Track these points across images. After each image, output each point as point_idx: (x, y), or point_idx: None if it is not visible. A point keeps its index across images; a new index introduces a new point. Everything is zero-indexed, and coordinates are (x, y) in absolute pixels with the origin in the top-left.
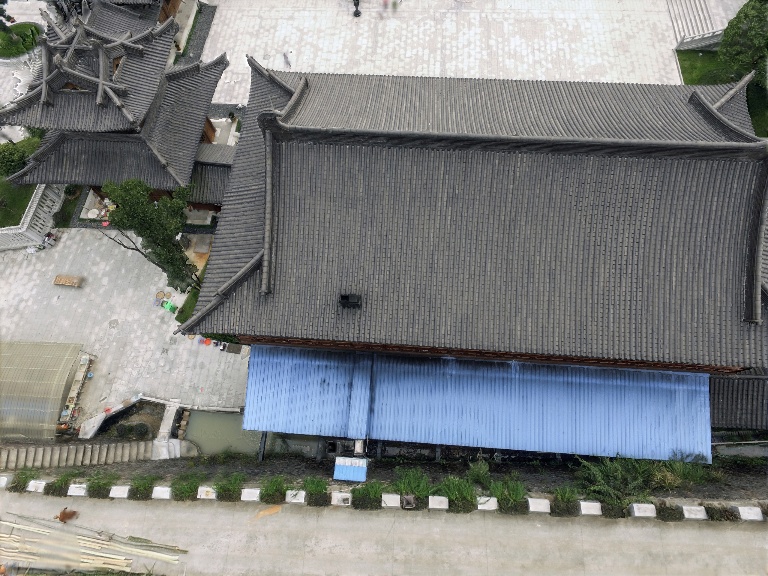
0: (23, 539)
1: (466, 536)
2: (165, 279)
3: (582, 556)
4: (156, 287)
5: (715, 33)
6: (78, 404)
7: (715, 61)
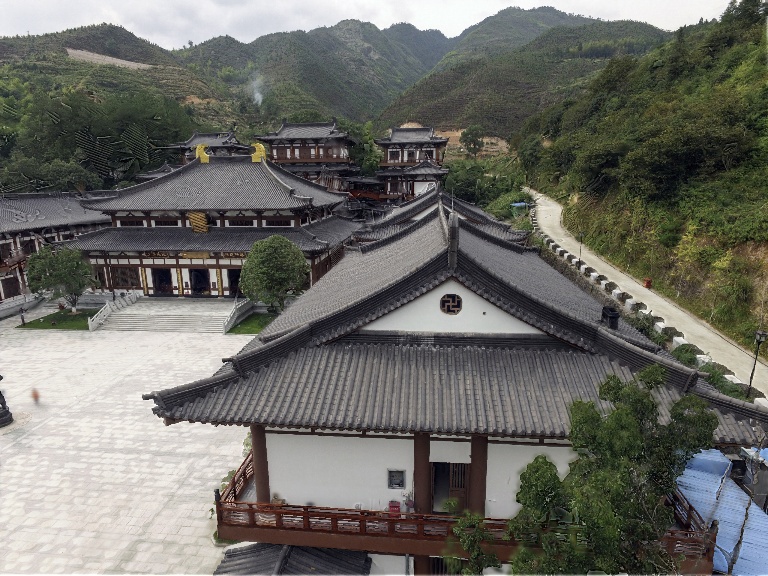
0: None
1: (743, 376)
2: None
3: (697, 336)
4: None
5: (233, 312)
6: None
7: (249, 323)
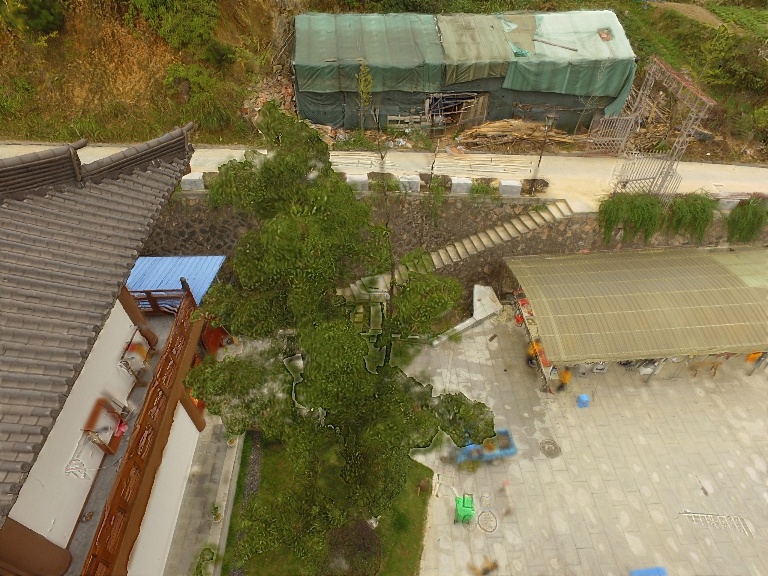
0: (455, 163)
1: None
2: (497, 567)
3: None
4: (508, 542)
5: None
6: (525, 329)
7: None
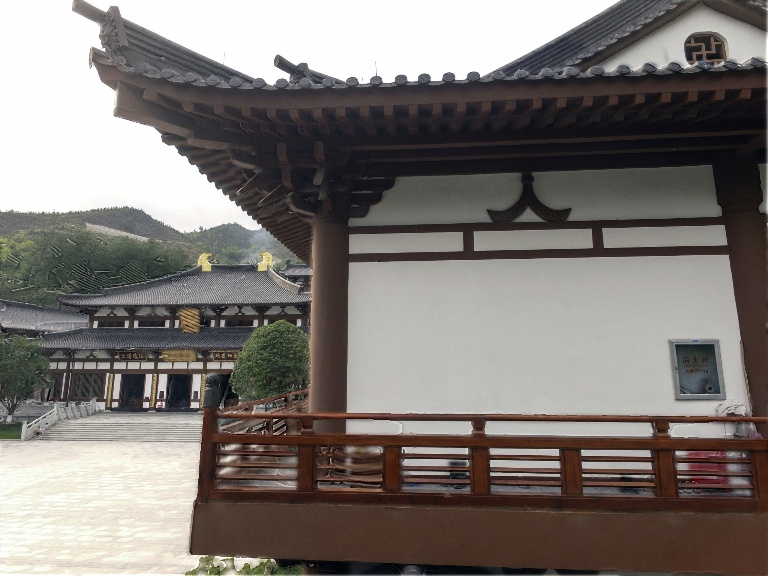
0: None
1: None
2: None
3: None
4: None
5: None
6: None
7: None
